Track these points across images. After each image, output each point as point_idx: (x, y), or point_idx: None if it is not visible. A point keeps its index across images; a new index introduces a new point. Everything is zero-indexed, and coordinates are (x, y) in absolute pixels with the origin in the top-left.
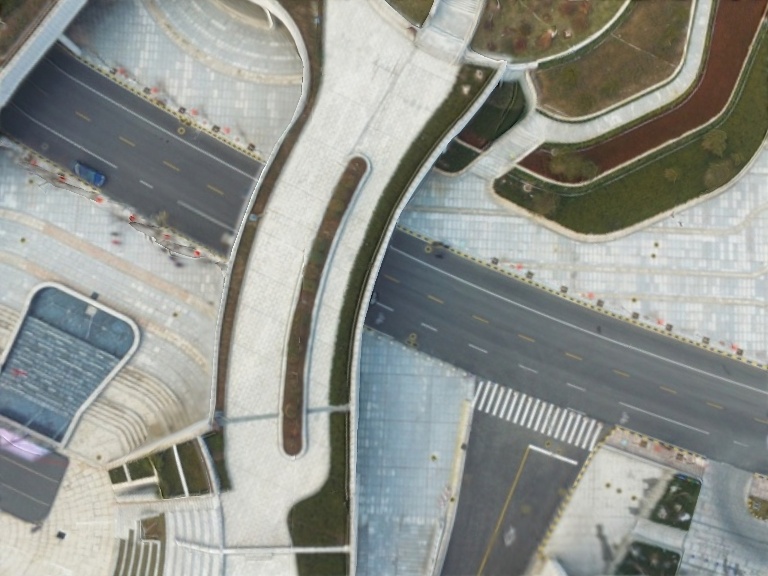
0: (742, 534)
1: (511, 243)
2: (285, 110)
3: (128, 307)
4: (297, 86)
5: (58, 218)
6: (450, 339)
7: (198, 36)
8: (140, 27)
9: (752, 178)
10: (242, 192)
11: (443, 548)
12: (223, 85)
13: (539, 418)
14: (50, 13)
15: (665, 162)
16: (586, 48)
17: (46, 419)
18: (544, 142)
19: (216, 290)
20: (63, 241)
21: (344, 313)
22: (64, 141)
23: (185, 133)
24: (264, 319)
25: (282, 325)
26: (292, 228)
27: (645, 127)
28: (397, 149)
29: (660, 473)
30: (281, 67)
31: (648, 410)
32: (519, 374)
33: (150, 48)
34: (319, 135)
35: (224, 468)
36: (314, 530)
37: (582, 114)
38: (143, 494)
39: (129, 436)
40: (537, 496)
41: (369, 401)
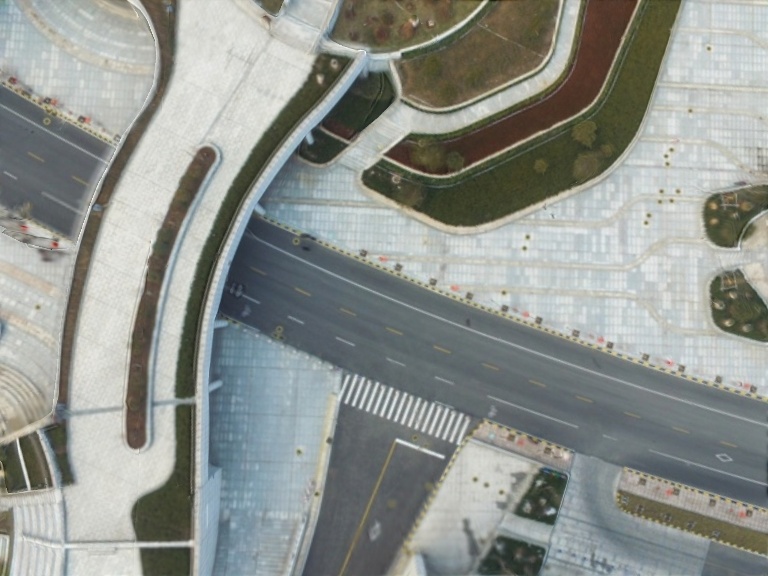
0: (610, 528)
1: (380, 235)
2: None
3: None
4: None
5: None
6: (317, 332)
7: (65, 25)
8: (6, 16)
9: (626, 170)
10: None
11: (307, 543)
12: (90, 75)
13: (406, 412)
14: None
15: (536, 153)
16: (451, 38)
17: None
18: (410, 133)
19: None
20: None
21: (190, 305)
22: None
23: (51, 124)
24: (109, 311)
25: (128, 317)
26: (138, 219)
27: (514, 118)
28: (249, 139)
29: (528, 467)
30: (149, 57)
31: (517, 404)
32: (386, 367)
33: (16, 37)
34: (169, 125)
35: (67, 461)
36: (158, 524)
37: (447, 104)
38: None
39: None
40: (403, 490)
41: (233, 394)
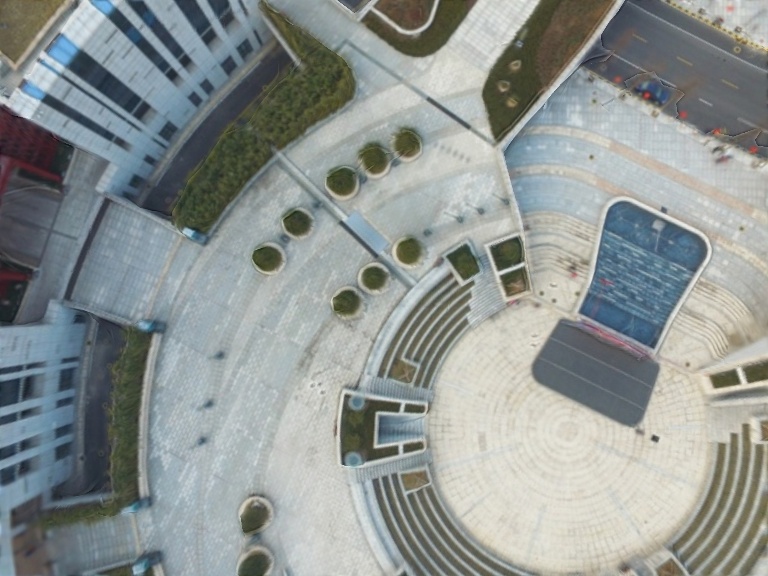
0: None
1: None
2: None
3: (697, 221)
4: None
5: (622, 136)
6: None
7: None
8: None
9: None
10: None
11: None
12: None
13: None
14: None
15: None
16: None
17: (637, 326)
18: None
19: None
20: (629, 158)
21: None
22: (623, 62)
23: (741, 52)
24: None
25: None
26: None
27: None
28: None
29: None
30: None
31: None
32: None
33: None
34: None
35: None
36: None
37: None
38: (760, 396)
39: (714, 344)
40: None
41: None
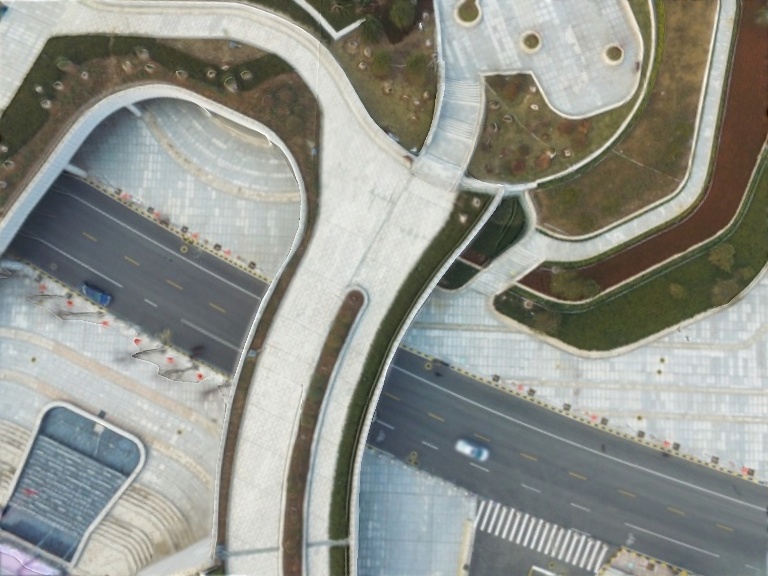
0: None
1: (512, 360)
2: (285, 227)
3: (134, 425)
4: (297, 203)
5: (67, 337)
6: (451, 457)
7: (199, 155)
8: (143, 147)
9: (762, 290)
10: (243, 310)
11: None
12: (224, 203)
13: (542, 539)
14: (56, 149)
15: (670, 276)
16: (586, 166)
17: (56, 539)
18: (544, 261)
19: (219, 408)
20: (72, 360)
21: (342, 448)
22: (72, 261)
23: (188, 252)
24: (264, 453)
25: (281, 459)
26: (290, 362)
27: (649, 242)
28: (394, 280)
29: None
30: (281, 184)
31: (655, 531)
32: (521, 493)
33: (153, 168)
34: (316, 267)
35: None
36: None
37: (583, 233)
38: None
39: (136, 555)
40: None
41: (370, 520)
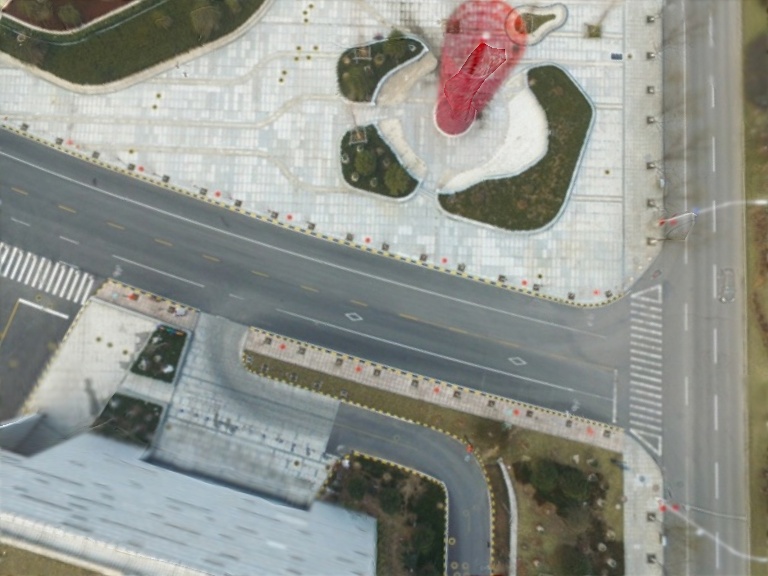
0: (235, 388)
1: (7, 95)
2: None
3: None
4: None
5: None
6: None
7: None
8: None
9: (263, 27)
10: None
11: None
12: None
13: (30, 272)
14: None
15: (163, 9)
16: None
17: None
18: None
19: None
20: None
21: None
22: None
23: None
24: None
25: None
26: None
27: None
28: None
29: (151, 326)
30: None
31: (142, 263)
32: (11, 227)
33: None
34: None
35: None
36: None
37: None
38: None
39: None
40: (26, 350)
41: None
